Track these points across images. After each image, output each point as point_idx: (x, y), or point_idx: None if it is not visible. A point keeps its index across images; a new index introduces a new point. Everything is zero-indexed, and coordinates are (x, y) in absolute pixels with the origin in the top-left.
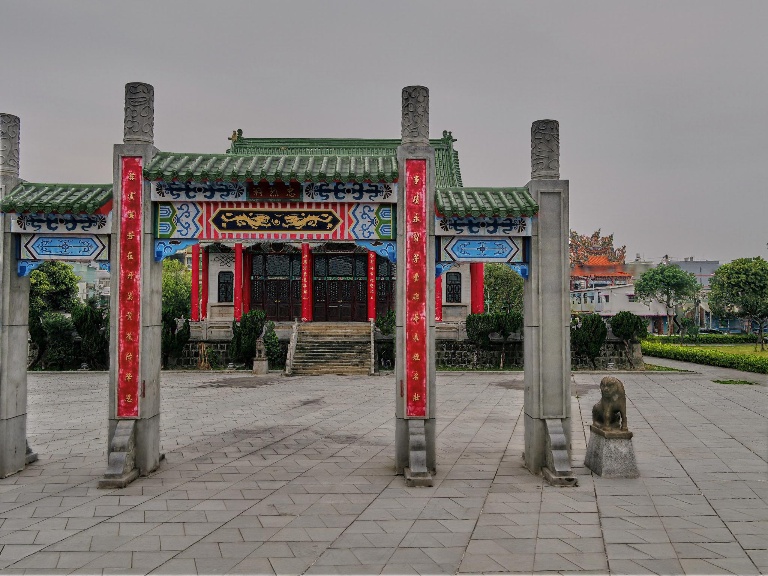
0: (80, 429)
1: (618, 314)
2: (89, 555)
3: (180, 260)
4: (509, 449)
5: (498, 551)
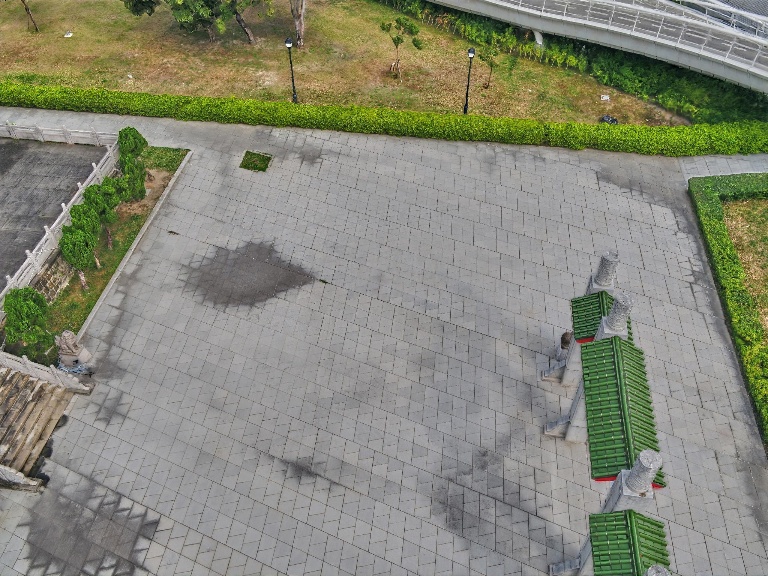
0: None
1: (124, 138)
2: (716, 568)
3: None
4: (522, 381)
5: (685, 430)
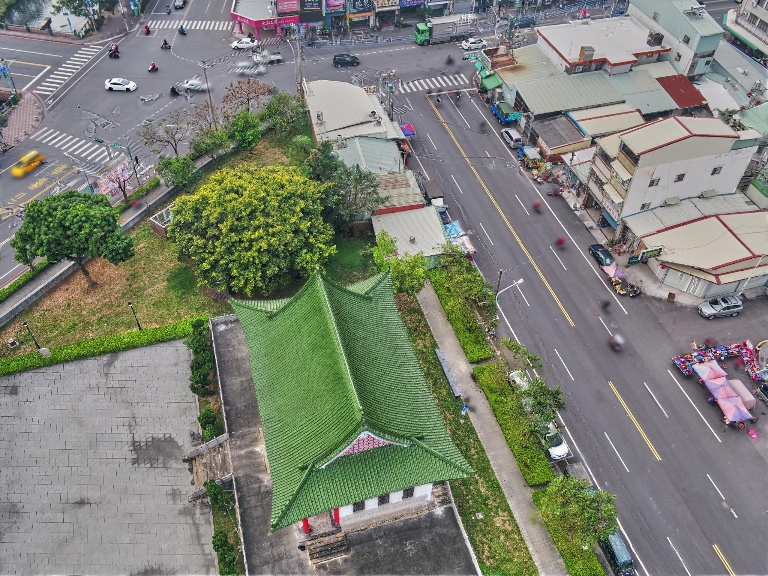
0: (24, 462)
1: None
2: None
3: (612, 160)
4: None
5: None
